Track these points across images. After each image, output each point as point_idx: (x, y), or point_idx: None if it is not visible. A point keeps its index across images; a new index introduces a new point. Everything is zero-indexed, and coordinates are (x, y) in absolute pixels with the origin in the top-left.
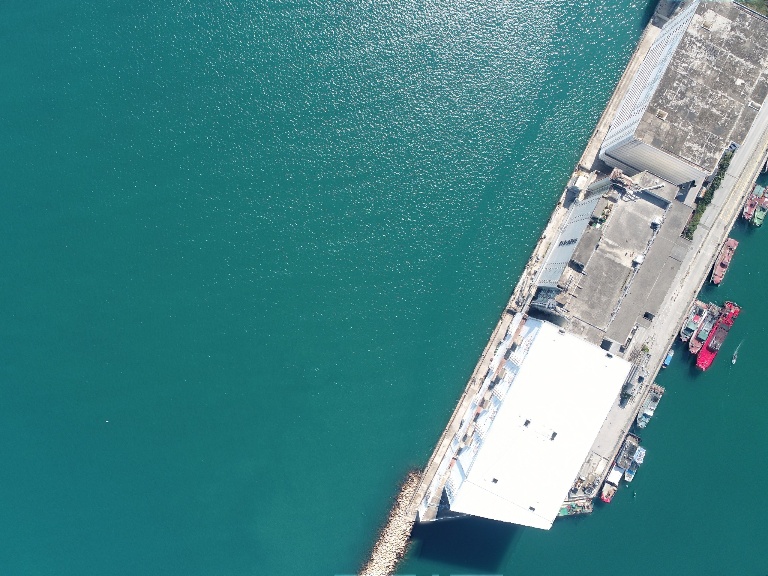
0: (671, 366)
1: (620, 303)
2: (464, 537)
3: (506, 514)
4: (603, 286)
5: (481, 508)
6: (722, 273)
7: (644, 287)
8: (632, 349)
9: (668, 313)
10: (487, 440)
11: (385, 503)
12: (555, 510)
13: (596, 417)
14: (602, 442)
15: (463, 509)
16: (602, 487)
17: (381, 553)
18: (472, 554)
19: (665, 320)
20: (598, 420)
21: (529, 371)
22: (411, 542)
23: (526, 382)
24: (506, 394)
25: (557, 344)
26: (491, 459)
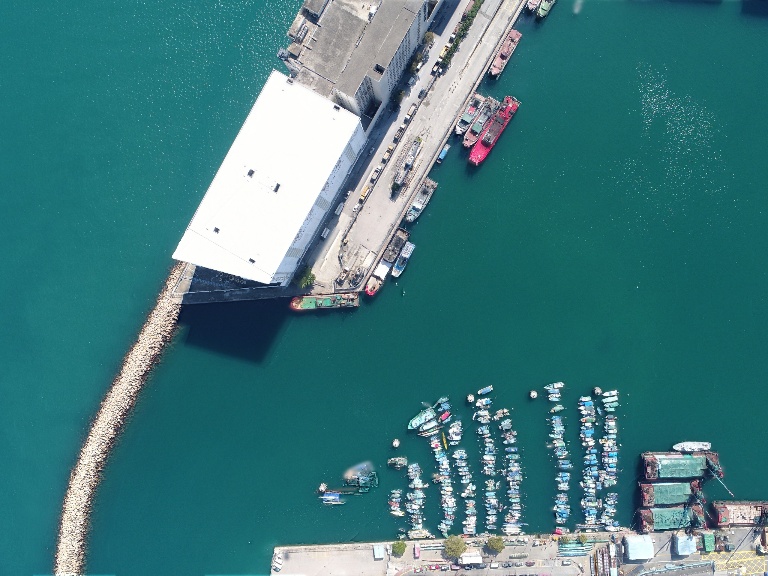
0: (447, 162)
1: (351, 54)
2: (229, 324)
3: (226, 265)
4: (338, 39)
5: (202, 257)
6: (501, 64)
7: (376, 39)
8: (406, 141)
9: (445, 105)
10: (212, 189)
11: (156, 287)
12: (276, 264)
13: (320, 170)
14: (371, 235)
15: (184, 257)
16: (368, 280)
17: (146, 334)
18: (237, 342)
19: (441, 112)
20: (322, 174)
21: (256, 121)
22: (178, 326)
23: (252, 131)
24: (234, 144)
25: (285, 93)
26: (214, 208)
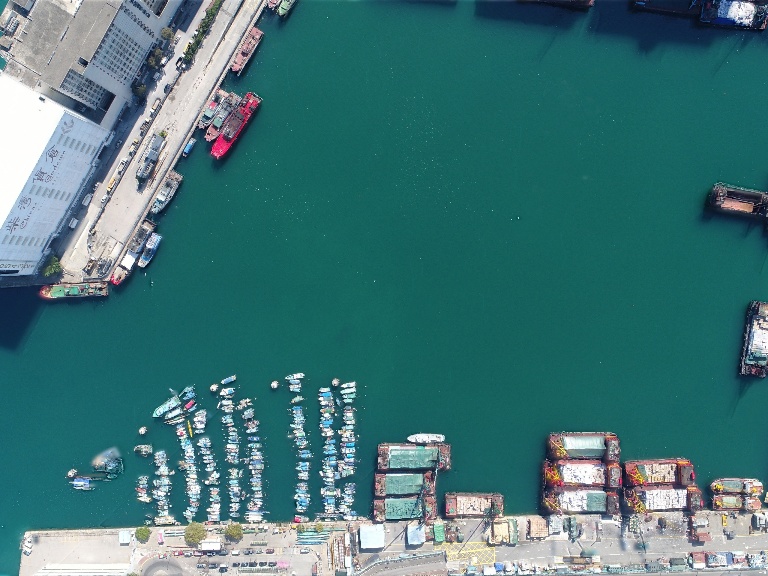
0: (194, 156)
1: (56, 47)
2: None
3: None
4: (48, 32)
5: None
6: (242, 61)
7: (80, 33)
8: None
9: (190, 100)
10: None
11: None
12: None
13: (26, 160)
14: (119, 226)
15: None
16: None
17: None
18: None
19: (186, 107)
20: (28, 163)
21: None
22: None
23: None
24: None
25: None
26: None
